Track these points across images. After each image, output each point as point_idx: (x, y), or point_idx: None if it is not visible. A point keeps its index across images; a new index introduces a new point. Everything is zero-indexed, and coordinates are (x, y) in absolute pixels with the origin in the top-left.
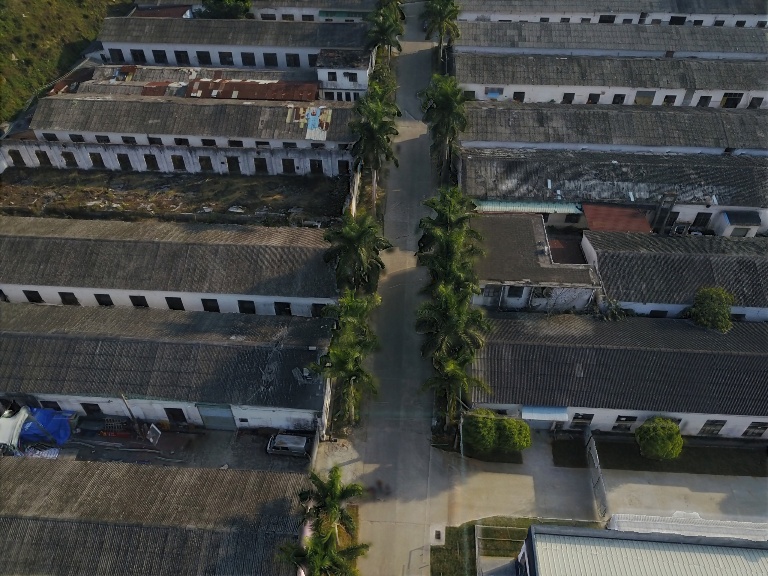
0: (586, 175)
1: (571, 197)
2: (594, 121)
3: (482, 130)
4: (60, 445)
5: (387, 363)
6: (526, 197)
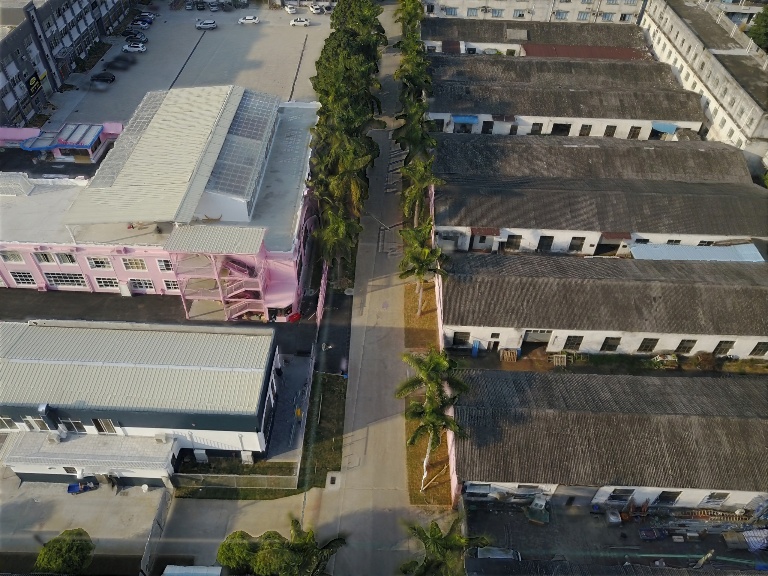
0: None
1: None
2: None
3: None
4: (756, 556)
5: None
6: None
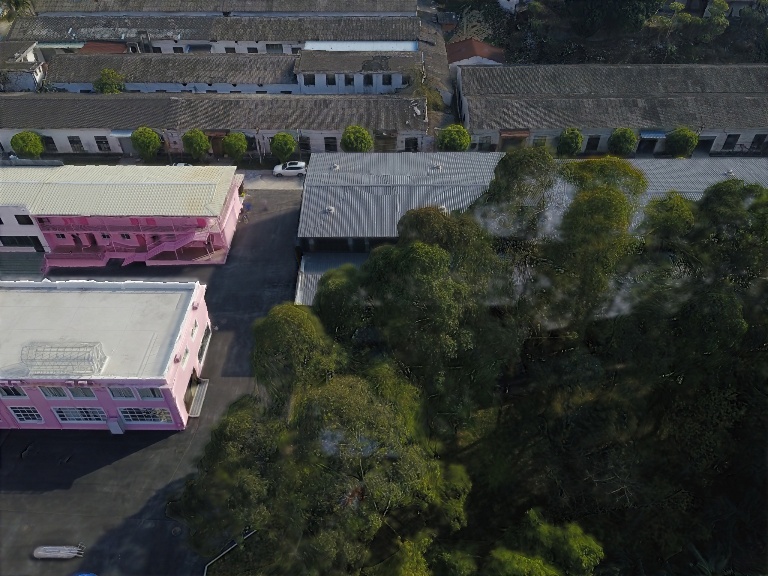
0: (98, 25)
1: (81, 38)
2: None
3: (53, 5)
4: None
5: None
6: (50, 39)
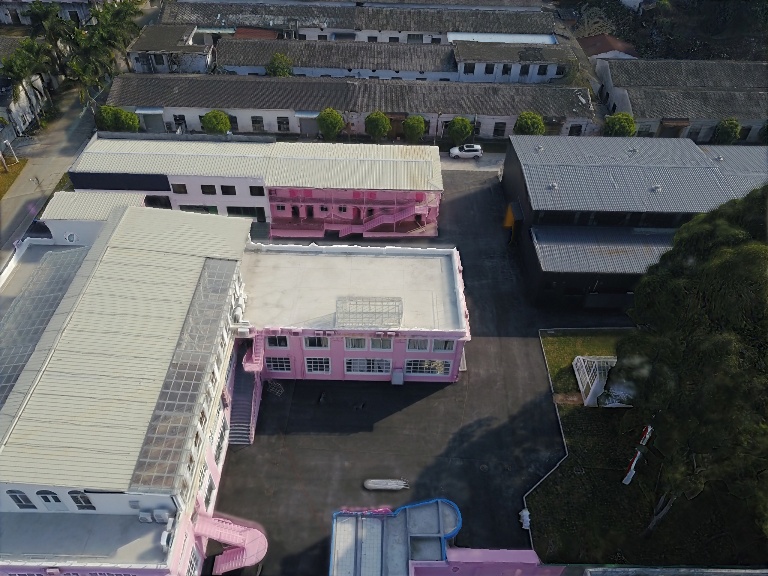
0: (245, 11)
1: (231, 23)
2: None
3: None
4: None
5: (78, 106)
6: (201, 24)
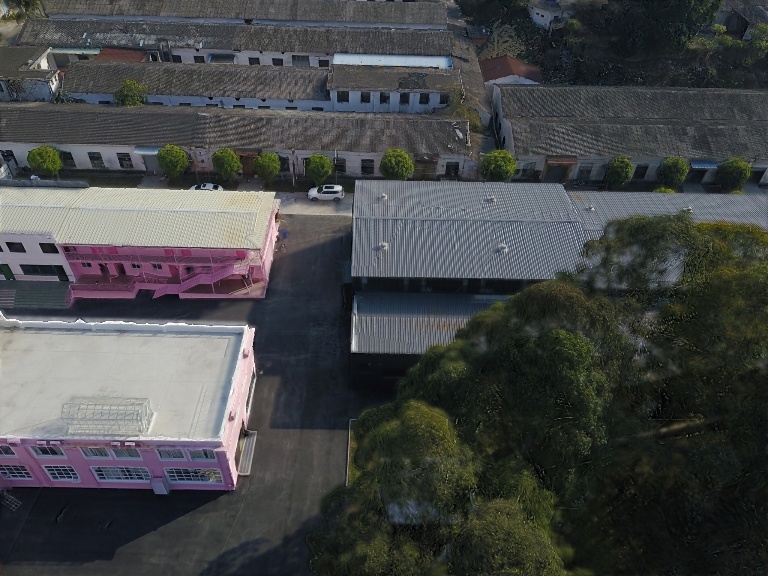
0: (114, 30)
1: (96, 43)
2: (152, 1)
3: (64, 6)
4: None
5: None
6: (63, 43)
